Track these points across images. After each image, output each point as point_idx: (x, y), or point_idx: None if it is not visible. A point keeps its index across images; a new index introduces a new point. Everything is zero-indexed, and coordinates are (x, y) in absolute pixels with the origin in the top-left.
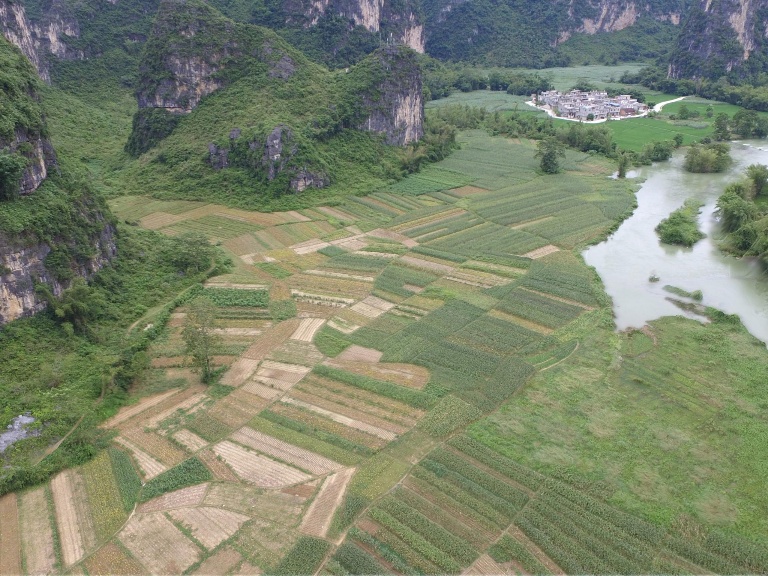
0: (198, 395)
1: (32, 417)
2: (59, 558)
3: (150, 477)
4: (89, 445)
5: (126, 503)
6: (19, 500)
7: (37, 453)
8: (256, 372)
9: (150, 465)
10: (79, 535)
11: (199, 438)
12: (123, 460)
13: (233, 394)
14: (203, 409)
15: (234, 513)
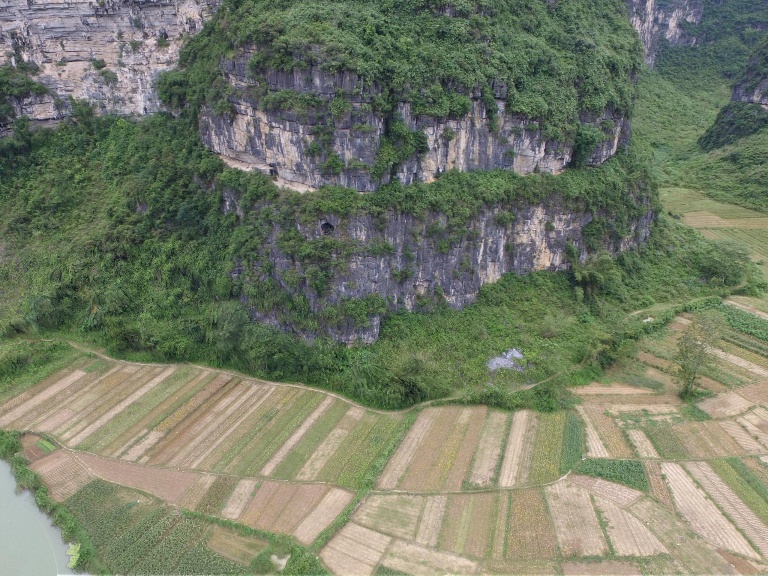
0: (669, 406)
1: (522, 354)
2: (496, 475)
3: (592, 455)
4: (554, 399)
5: (563, 465)
6: (488, 413)
7: (514, 384)
8: (744, 414)
9: (596, 445)
10: (517, 467)
11: (652, 447)
12: (576, 427)
13: (707, 423)
14: (668, 422)
15: (655, 537)
